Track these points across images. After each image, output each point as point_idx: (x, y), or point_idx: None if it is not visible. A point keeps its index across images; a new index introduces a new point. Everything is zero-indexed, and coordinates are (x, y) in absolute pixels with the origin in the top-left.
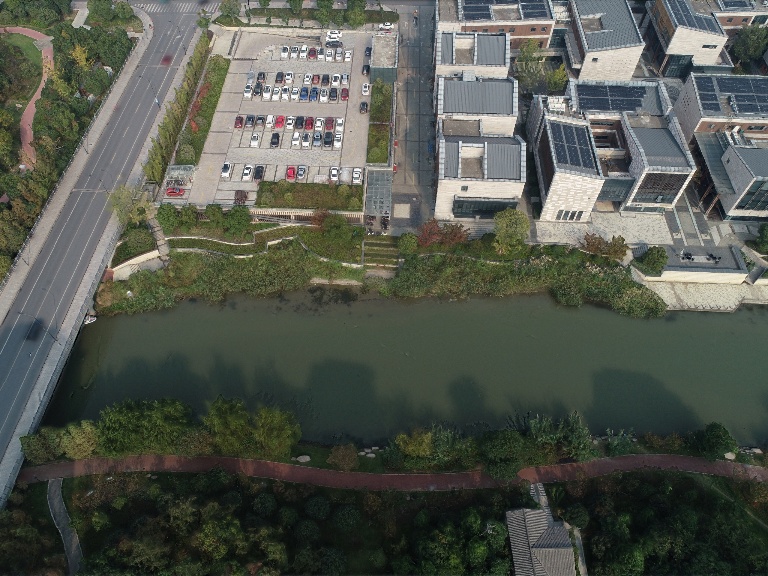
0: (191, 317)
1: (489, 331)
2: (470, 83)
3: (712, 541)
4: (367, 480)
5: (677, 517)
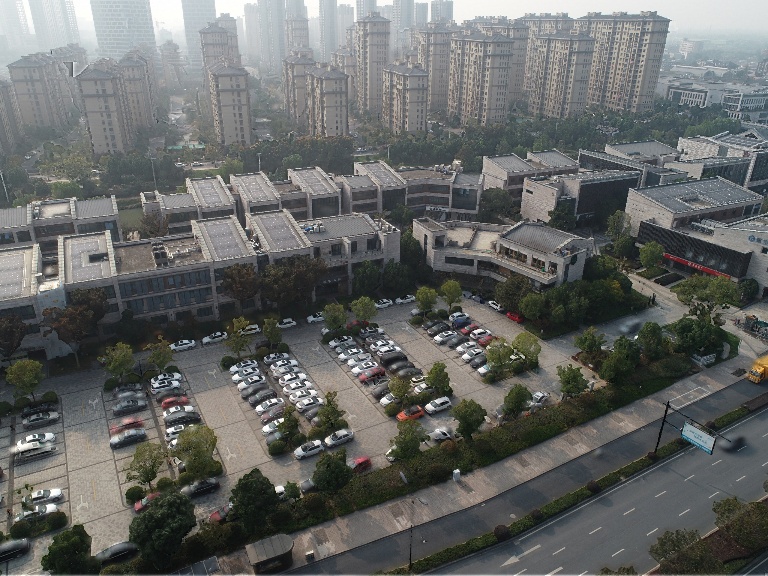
0: None
1: None
2: None
3: None
4: None
5: None
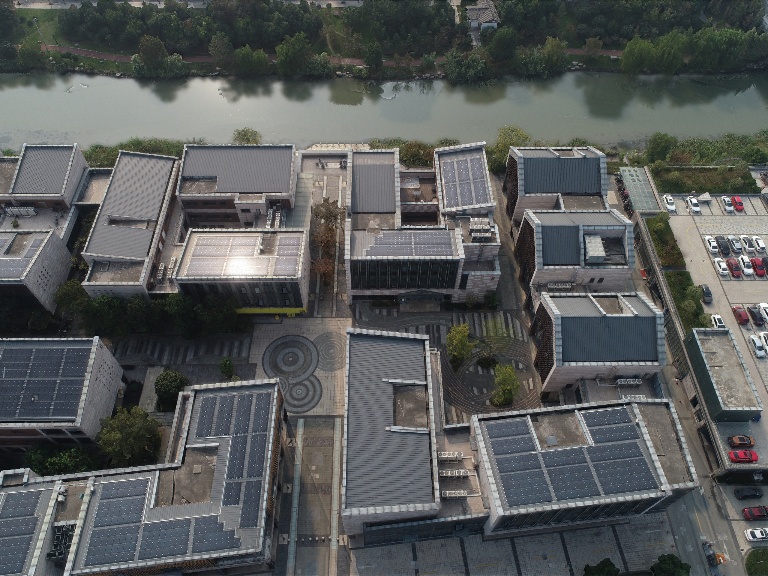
0: (738, 130)
1: (510, 125)
2: (593, 225)
3: (402, 2)
4: (574, 52)
5: (418, 7)
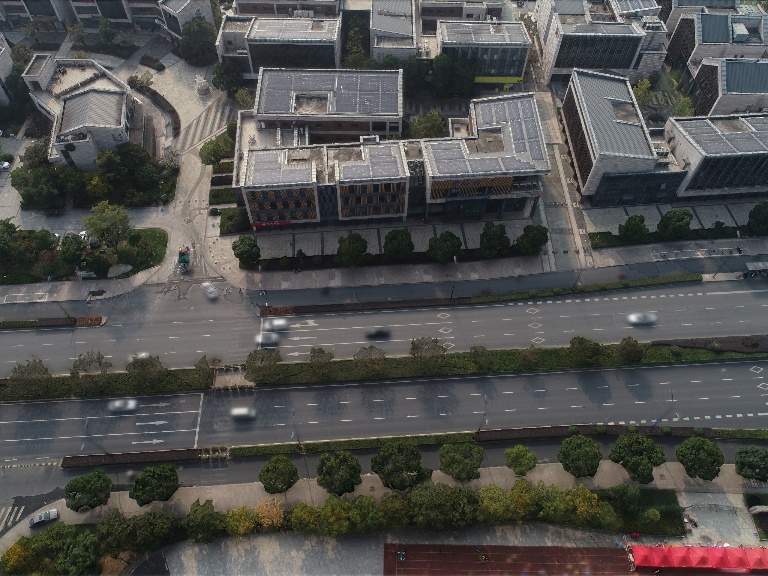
0: None
1: None
2: None
3: None
4: None
5: None
